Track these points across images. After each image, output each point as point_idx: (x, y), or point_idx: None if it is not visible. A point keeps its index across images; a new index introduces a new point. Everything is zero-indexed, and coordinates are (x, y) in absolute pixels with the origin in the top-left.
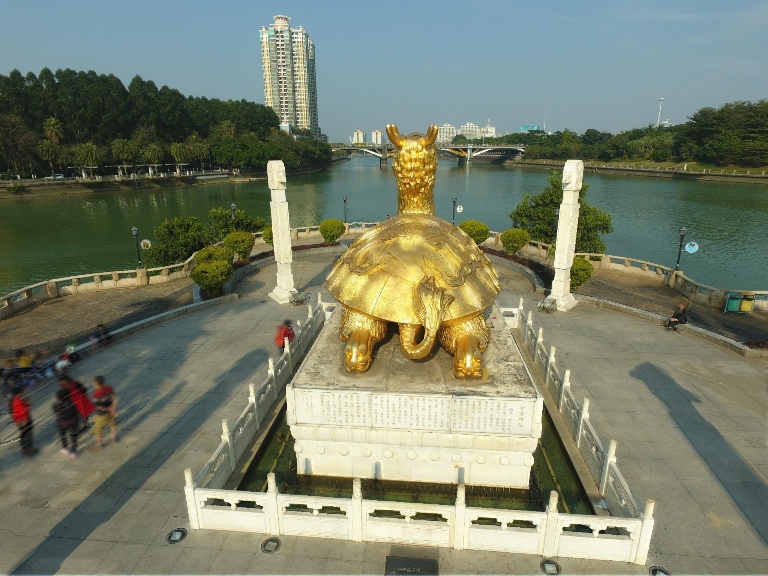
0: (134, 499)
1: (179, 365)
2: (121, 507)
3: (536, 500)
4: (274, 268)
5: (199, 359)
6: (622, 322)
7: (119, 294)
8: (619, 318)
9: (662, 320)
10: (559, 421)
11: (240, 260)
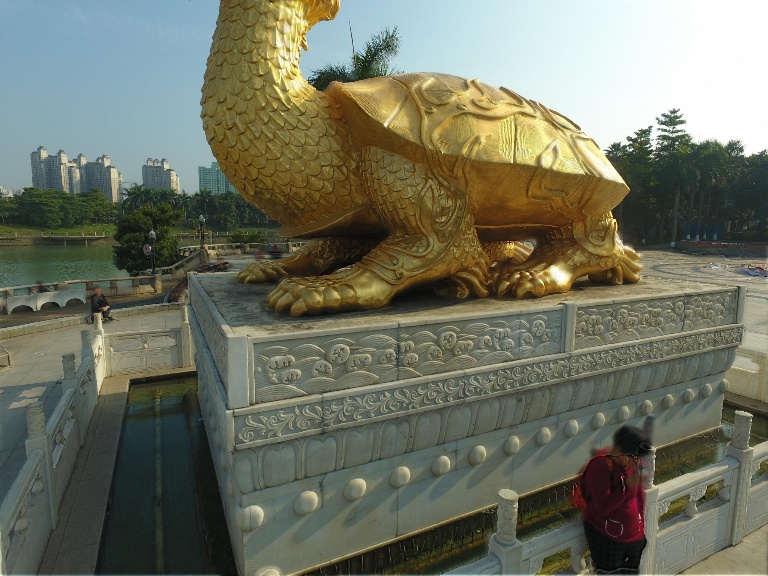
0: None
1: None
2: None
3: None
4: None
5: None
6: (72, 335)
7: None
8: (52, 336)
9: (82, 319)
10: None
11: None
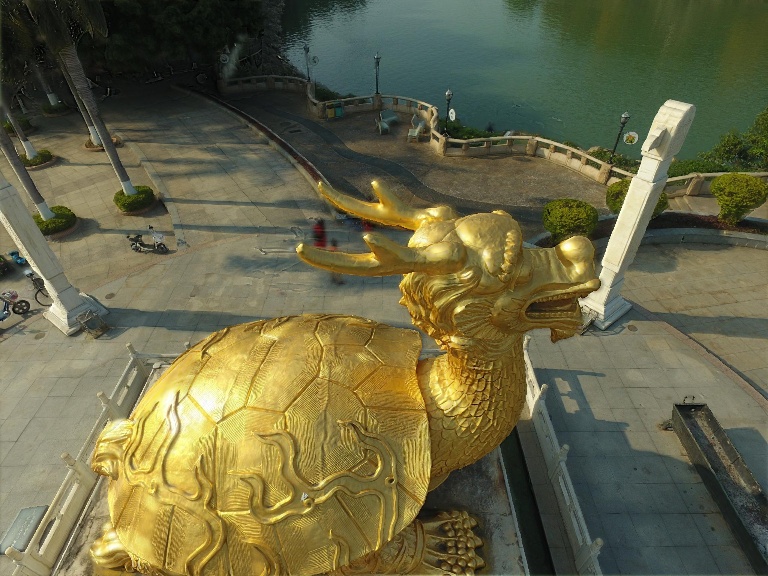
0: (184, 333)
1: (372, 283)
2: (179, 330)
3: None
4: (752, 259)
5: (386, 291)
6: None
7: (566, 180)
8: None
9: None
10: None
11: (718, 217)
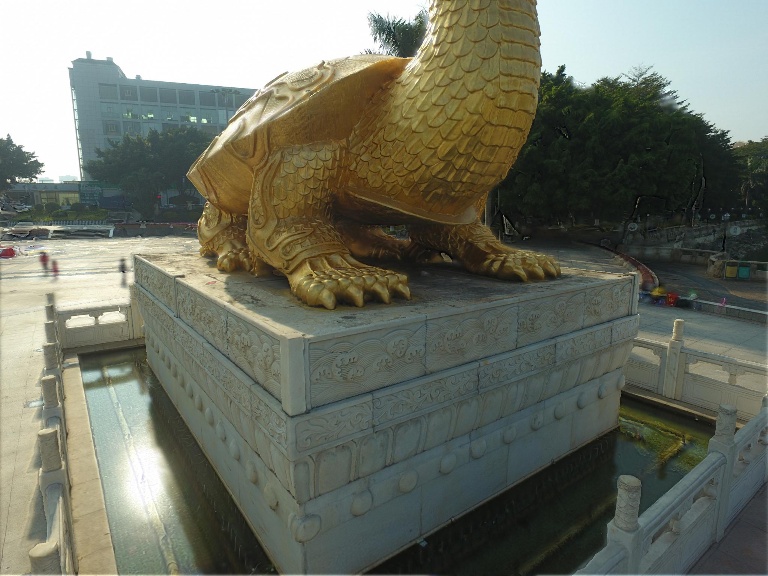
0: None
1: None
2: None
3: (140, 362)
4: None
5: None
6: None
7: None
8: None
9: None
10: (77, 417)
11: None
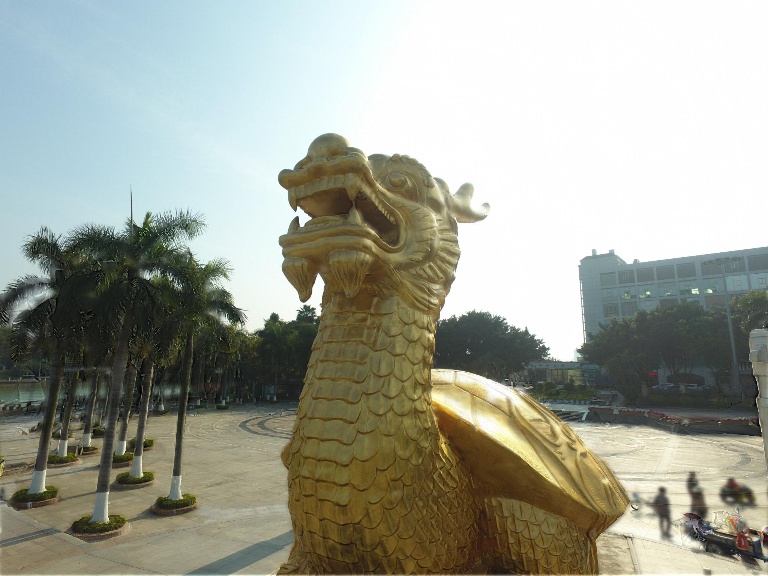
0: None
1: None
2: None
3: None
4: None
5: None
6: None
7: None
8: None
9: None
10: None
11: None
